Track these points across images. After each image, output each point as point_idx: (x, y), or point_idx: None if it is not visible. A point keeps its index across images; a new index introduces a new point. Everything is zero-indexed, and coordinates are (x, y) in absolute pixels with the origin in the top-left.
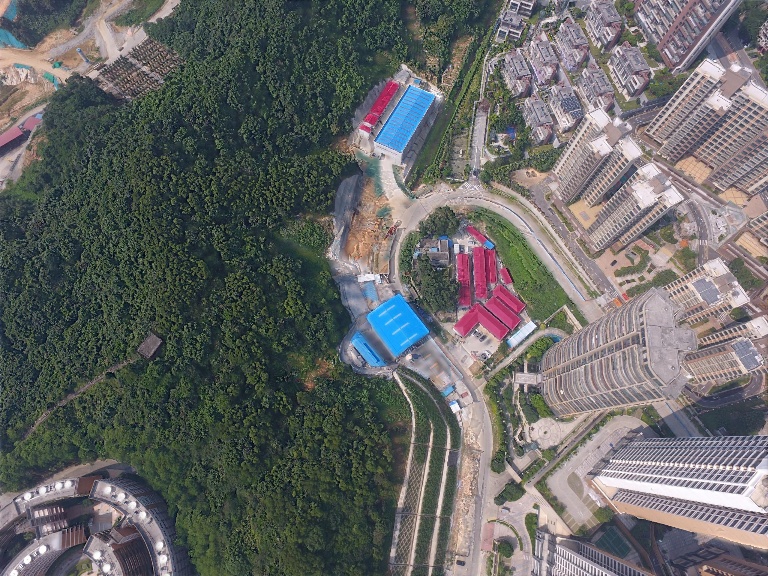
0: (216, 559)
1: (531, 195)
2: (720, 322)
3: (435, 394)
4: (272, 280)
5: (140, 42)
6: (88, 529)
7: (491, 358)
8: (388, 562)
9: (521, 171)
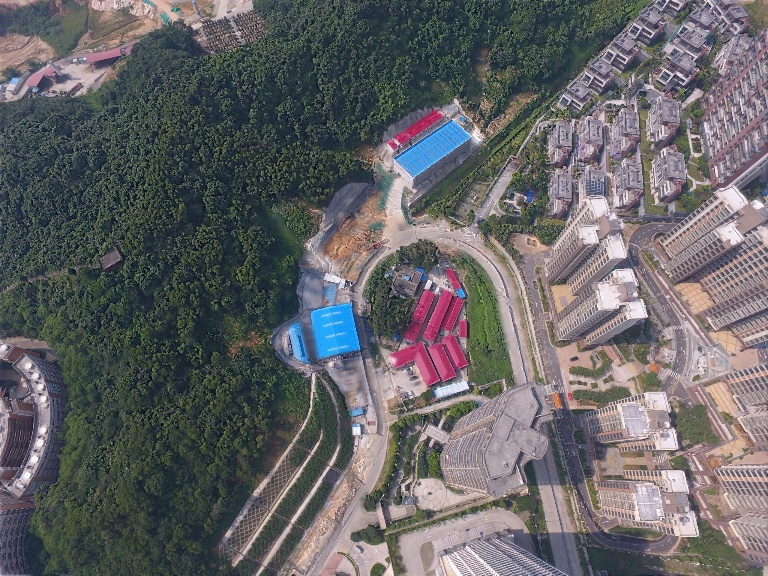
0: (76, 463)
1: (522, 262)
2: (655, 463)
3: (342, 409)
4: (239, 245)
5: (246, 11)
6: (9, 394)
7: (412, 400)
8: (220, 540)
9: (523, 236)
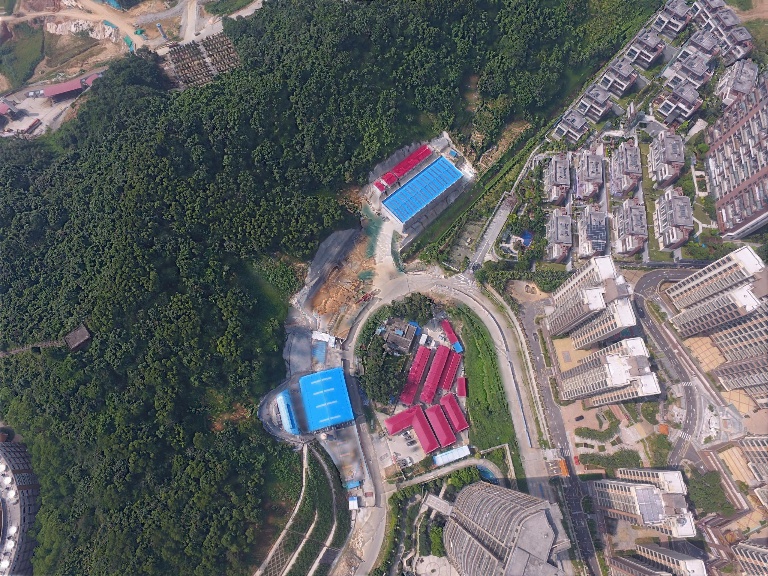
0: (51, 568)
1: (521, 312)
2: None
3: (337, 483)
4: (218, 312)
5: (216, 33)
6: None
7: (411, 467)
8: None
9: (521, 282)
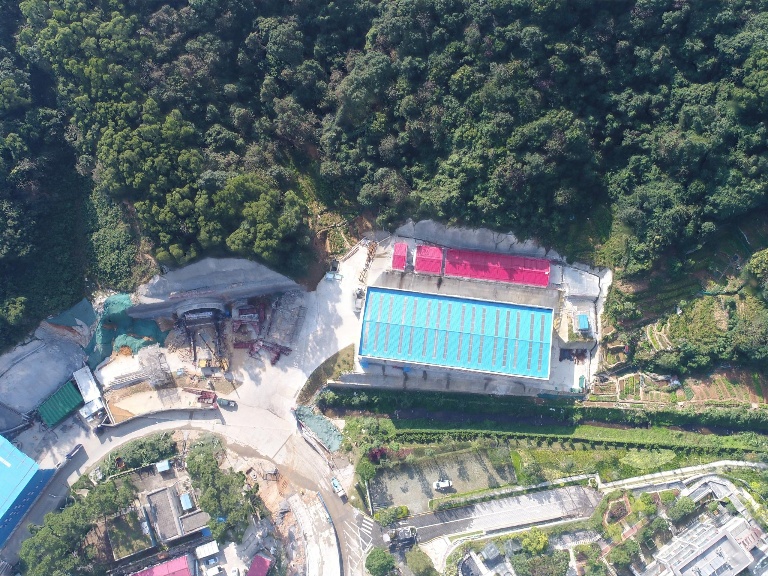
0: None
1: None
2: None
3: None
4: None
5: None
6: None
7: None
8: None
9: None
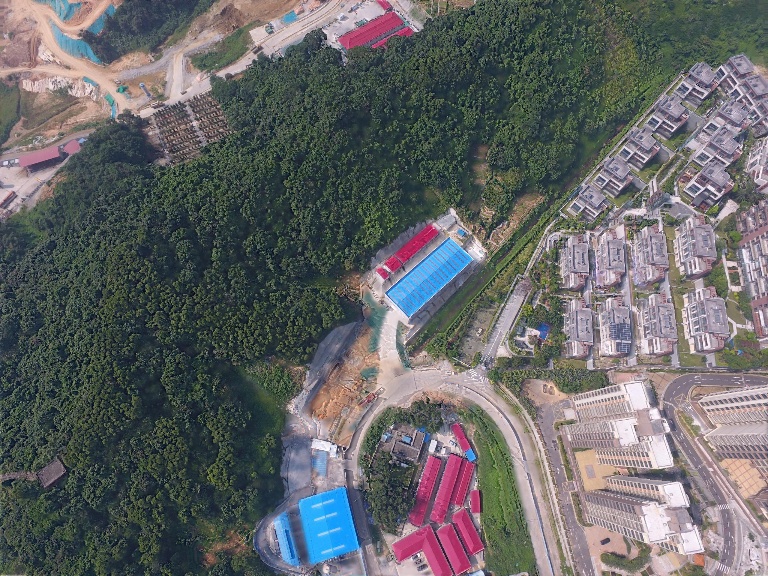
0: None
1: (539, 415)
2: None
3: None
4: (208, 434)
5: (204, 91)
6: None
7: None
8: None
9: (538, 381)
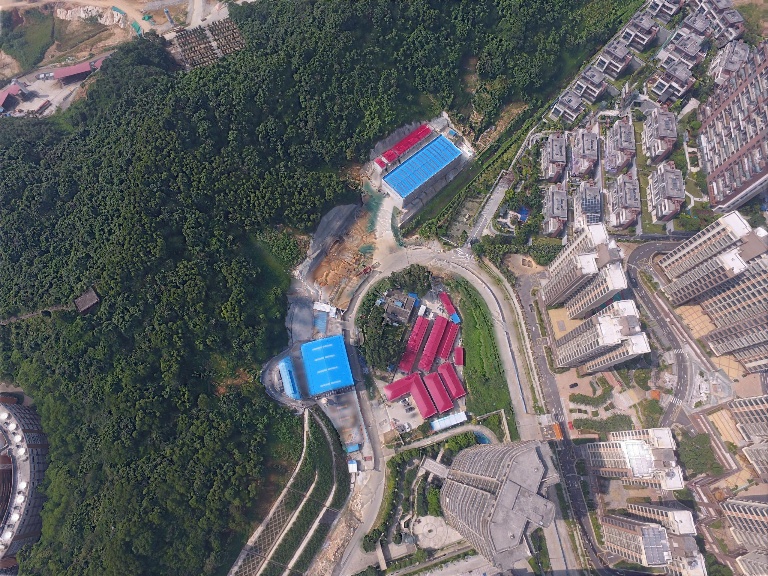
0: (60, 520)
1: (518, 284)
2: (659, 494)
3: (337, 446)
4: (223, 279)
5: (222, 18)
6: None
7: (409, 433)
8: None
9: (518, 256)
